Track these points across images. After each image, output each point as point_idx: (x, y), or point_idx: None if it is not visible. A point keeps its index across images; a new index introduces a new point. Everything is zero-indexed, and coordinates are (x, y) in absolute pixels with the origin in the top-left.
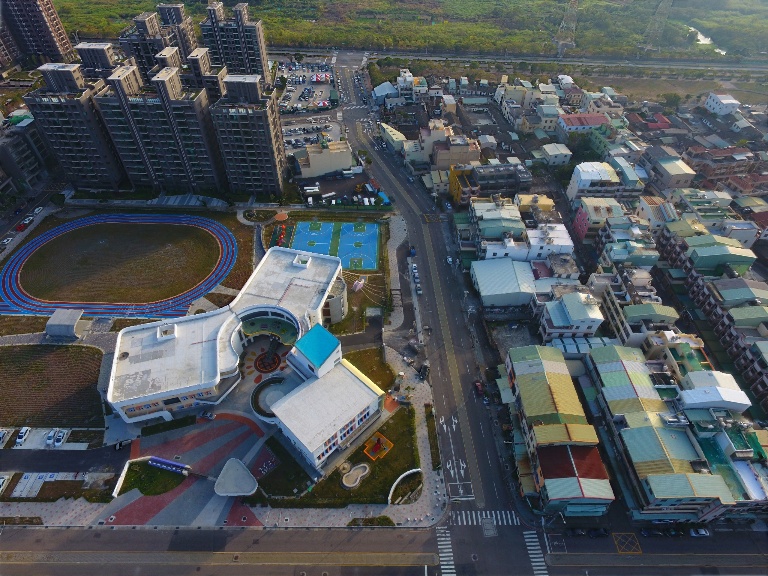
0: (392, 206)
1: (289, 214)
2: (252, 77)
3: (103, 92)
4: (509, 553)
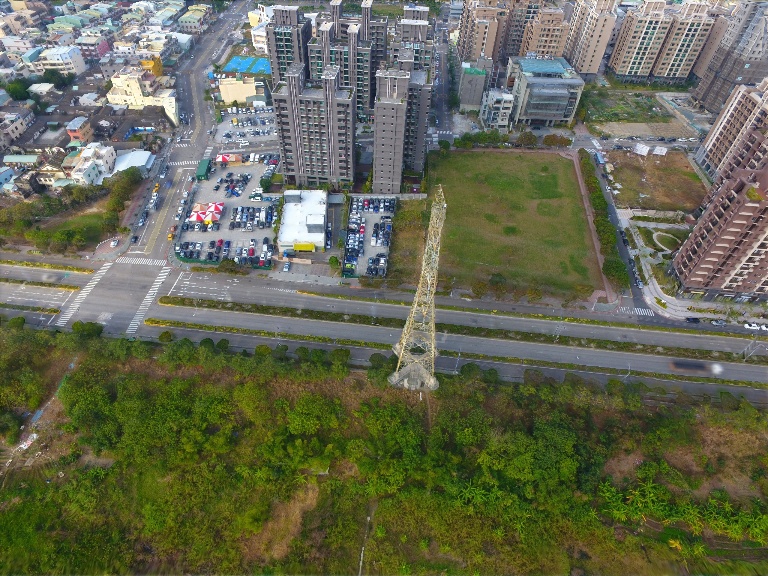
0: None
1: None
2: None
3: None
4: (228, 16)
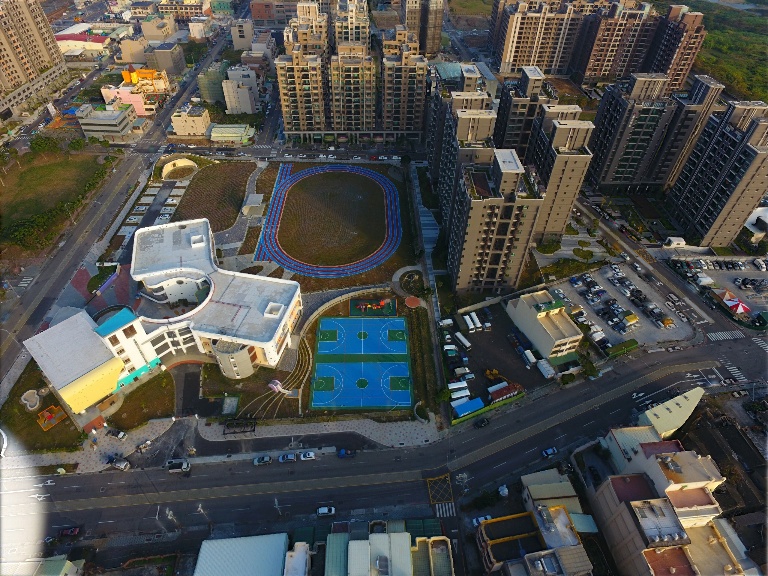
0: (454, 421)
1: (420, 308)
2: (517, 166)
3: None
4: None
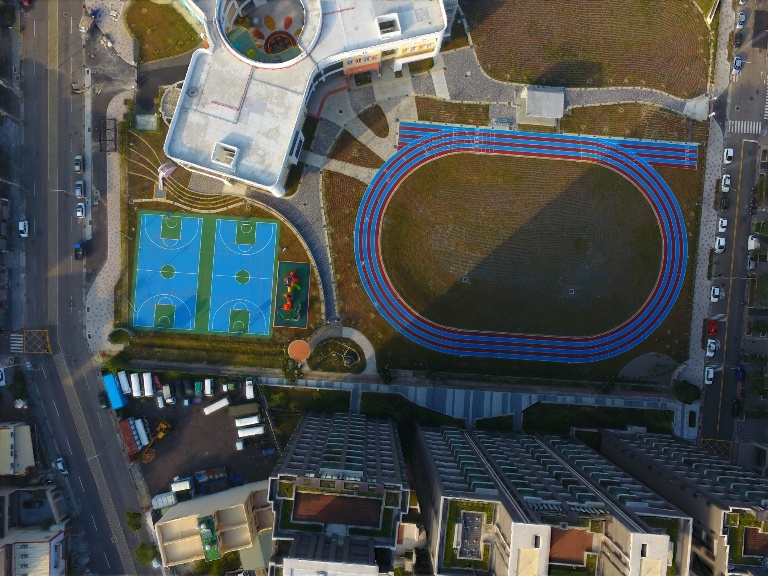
0: (102, 371)
1: None
2: None
3: (686, 560)
4: None
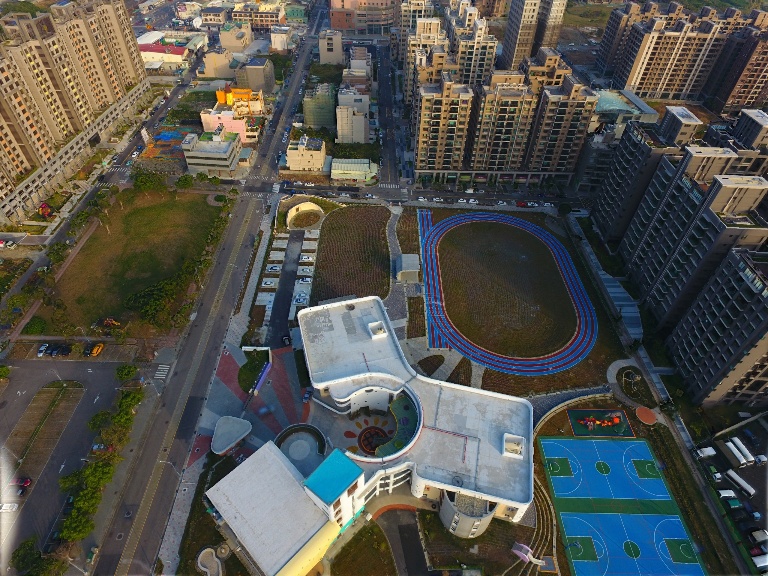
0: None
1: (659, 425)
2: None
3: None
4: None
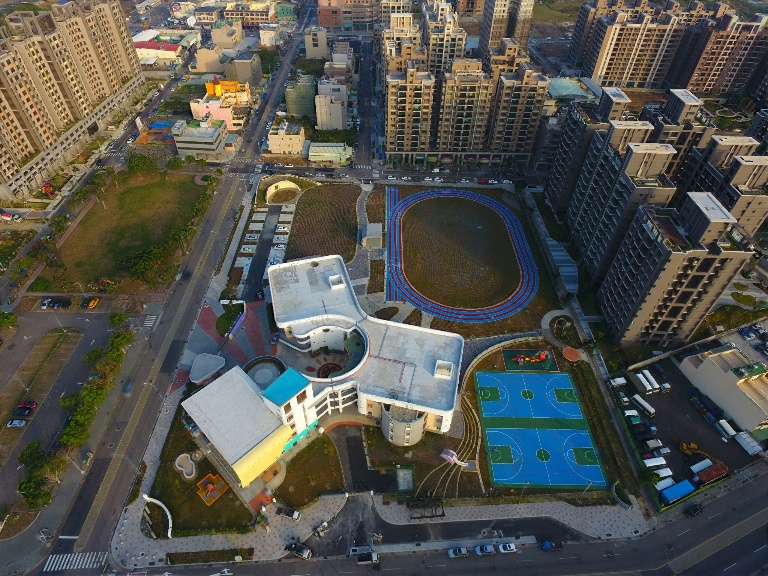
0: (664, 508)
1: (581, 362)
2: (724, 214)
3: None
4: None
